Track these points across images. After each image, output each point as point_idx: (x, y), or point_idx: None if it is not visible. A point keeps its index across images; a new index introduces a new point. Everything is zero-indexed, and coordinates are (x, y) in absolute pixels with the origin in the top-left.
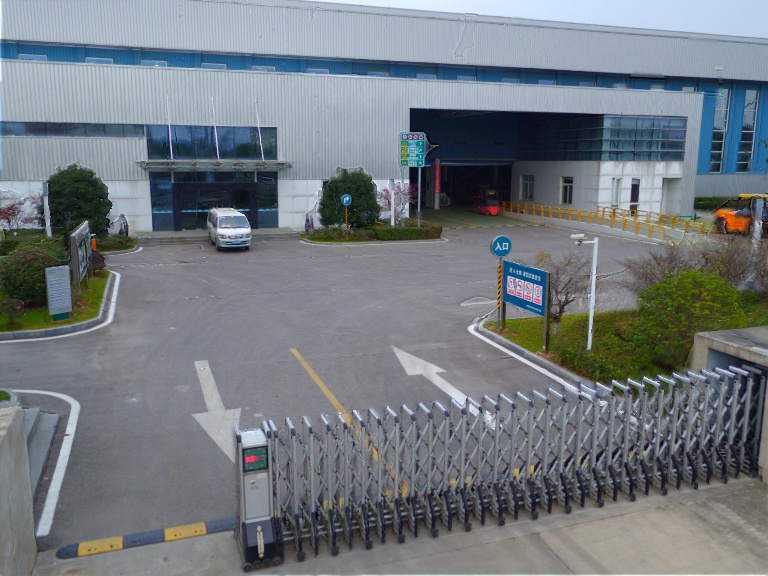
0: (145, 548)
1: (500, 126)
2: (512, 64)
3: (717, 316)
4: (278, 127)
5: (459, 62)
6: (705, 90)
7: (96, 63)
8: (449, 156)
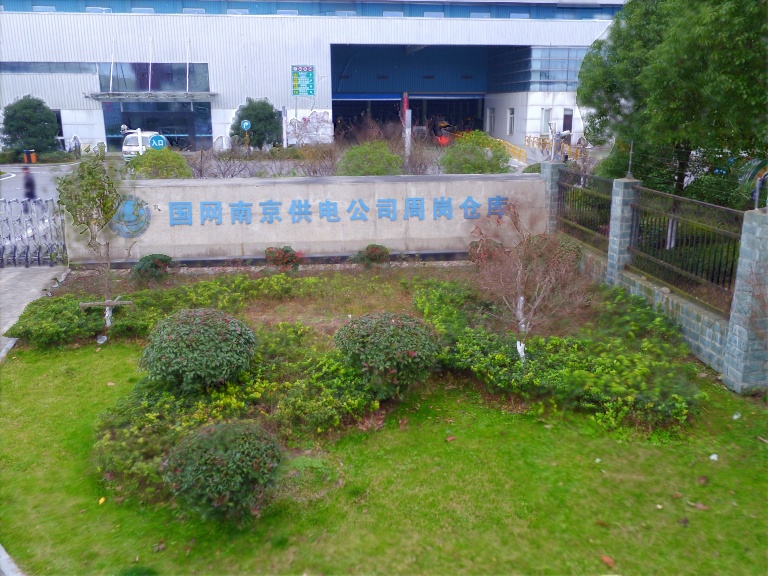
0: None
1: (468, 60)
2: None
3: (146, 176)
4: (209, 63)
5: None
6: None
7: (55, 12)
8: (416, 90)
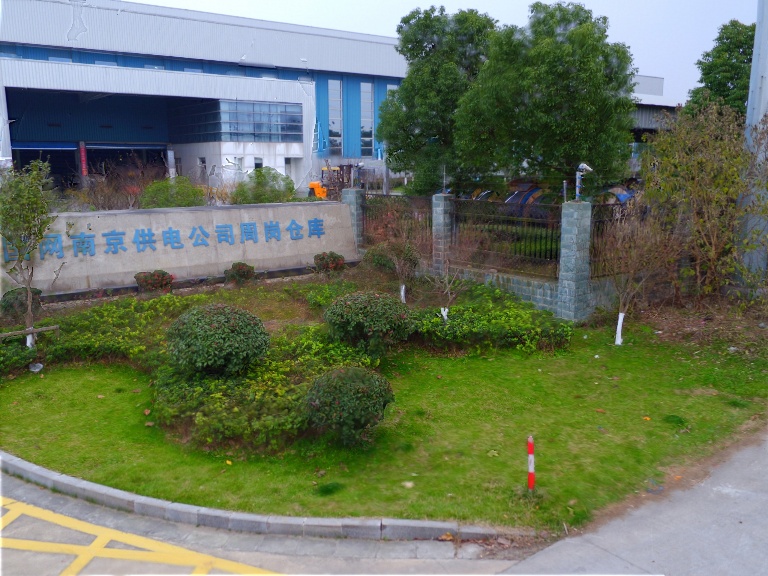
0: None
1: (147, 111)
2: (152, 52)
3: None
4: None
5: (92, 47)
6: (299, 79)
7: None
8: (94, 139)
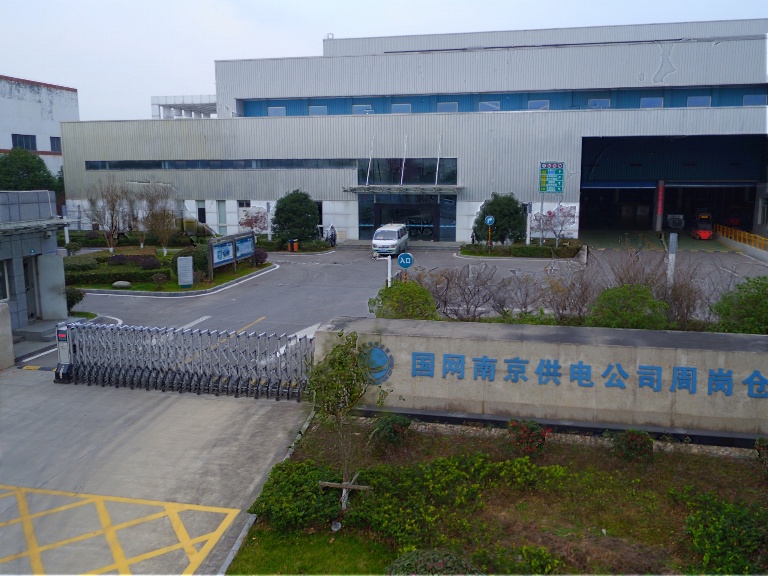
0: (44, 371)
1: (738, 146)
2: (753, 80)
3: (392, 312)
4: (458, 158)
5: (685, 83)
6: None
7: (326, 115)
8: (674, 178)
